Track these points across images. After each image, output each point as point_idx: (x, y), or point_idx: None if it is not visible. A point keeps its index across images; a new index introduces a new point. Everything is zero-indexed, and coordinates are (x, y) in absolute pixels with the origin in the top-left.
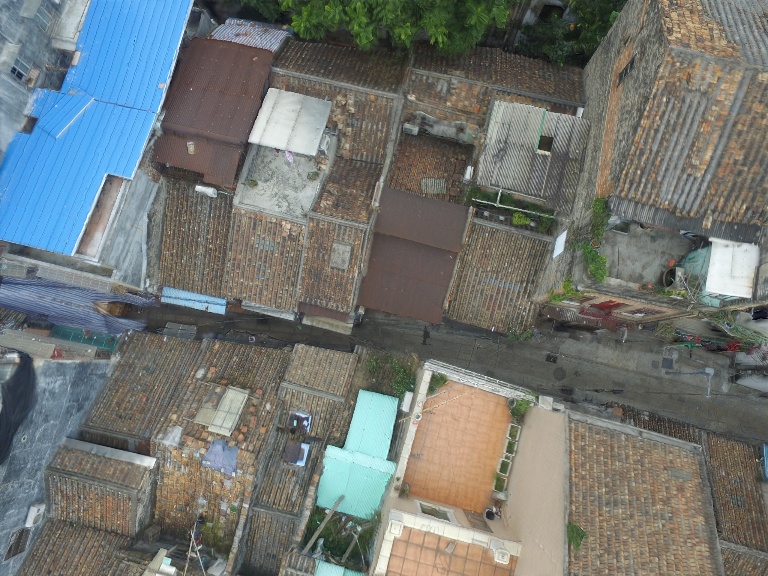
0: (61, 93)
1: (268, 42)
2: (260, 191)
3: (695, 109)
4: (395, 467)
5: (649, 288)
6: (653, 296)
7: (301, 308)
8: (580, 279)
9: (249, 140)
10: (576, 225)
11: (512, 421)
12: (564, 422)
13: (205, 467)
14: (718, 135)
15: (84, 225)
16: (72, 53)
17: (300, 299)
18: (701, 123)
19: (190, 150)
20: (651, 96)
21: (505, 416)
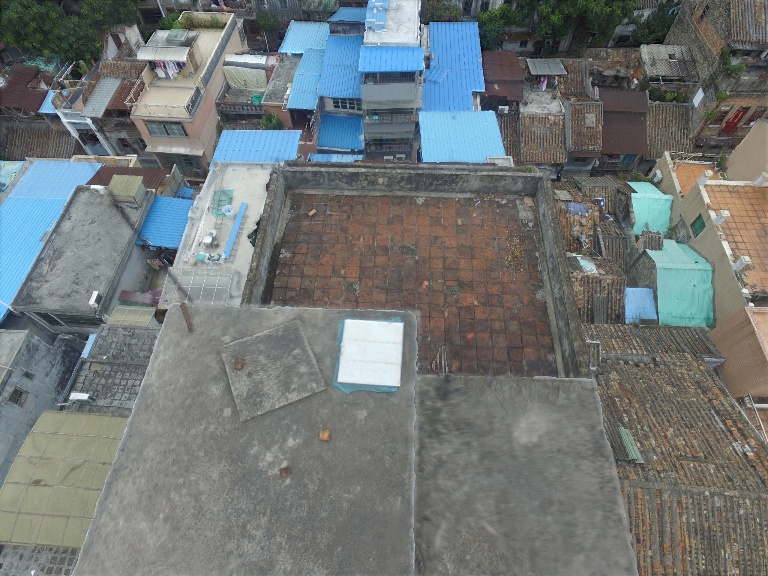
0: (431, 69)
1: None
2: (530, 107)
3: (750, 3)
4: (672, 196)
5: (764, 73)
6: (765, 84)
7: (572, 155)
8: (728, 83)
9: (532, 73)
10: (708, 77)
11: (719, 172)
12: (760, 122)
13: (569, 213)
14: (764, 9)
15: (473, 108)
16: (429, 55)
17: (572, 148)
18: (755, 7)
19: (496, 88)
20: (731, 1)
21: (713, 172)
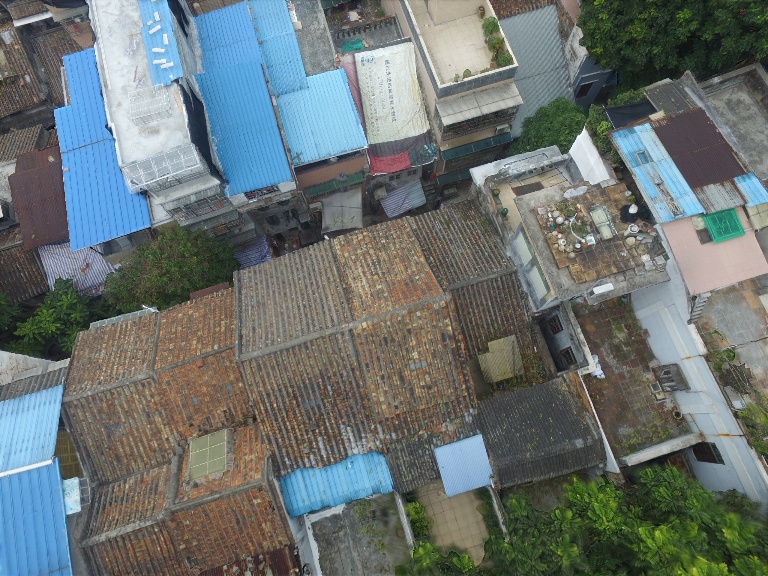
0: None
1: (57, 271)
2: None
3: None
4: None
5: None
6: None
7: None
8: None
9: None
10: None
11: None
12: None
13: None
14: None
15: None
16: None
17: None
18: None
19: (51, 158)
20: None
21: None
